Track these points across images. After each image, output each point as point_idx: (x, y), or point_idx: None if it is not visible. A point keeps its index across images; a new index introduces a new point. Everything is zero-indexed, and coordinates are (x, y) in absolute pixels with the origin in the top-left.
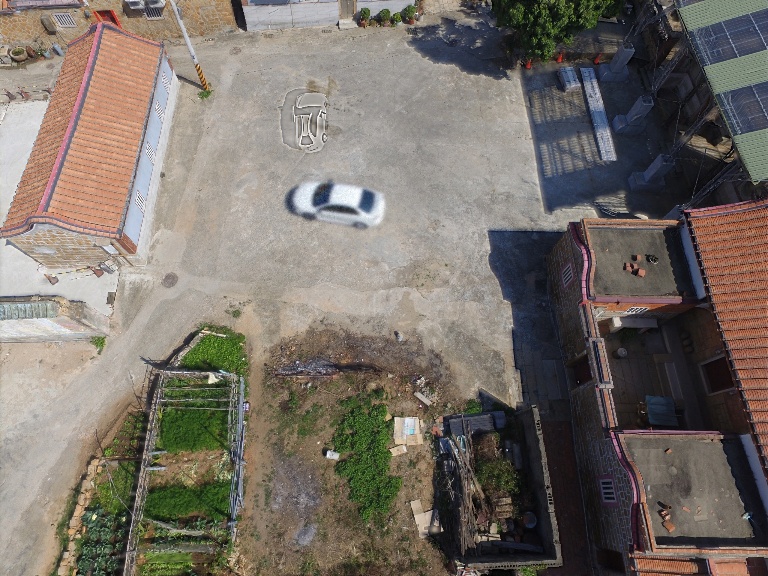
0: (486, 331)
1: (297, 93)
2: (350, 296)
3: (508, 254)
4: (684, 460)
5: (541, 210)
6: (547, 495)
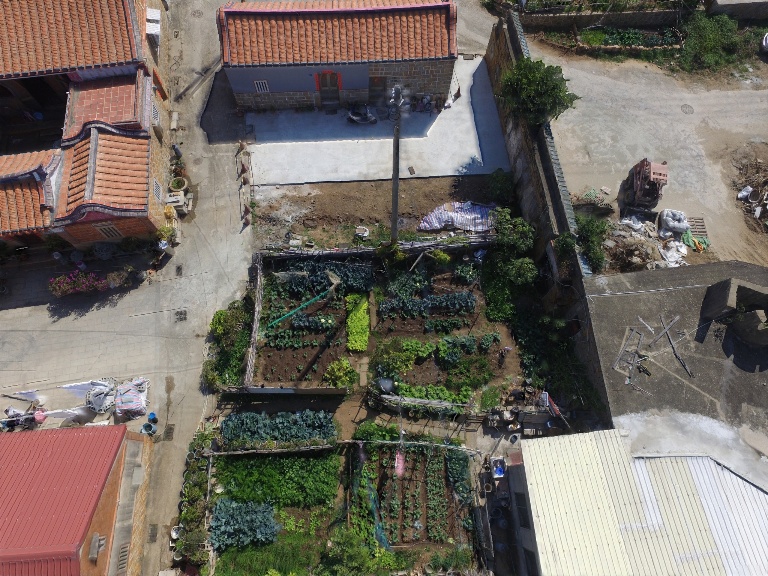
0: None
1: None
2: None
3: None
4: None
5: None
6: None
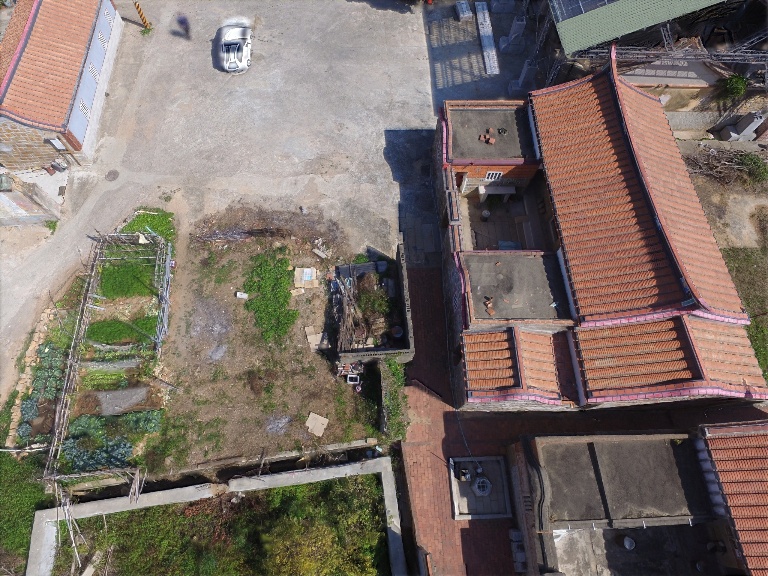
0: (377, 204)
1: (227, 28)
2: (264, 182)
3: (400, 147)
4: (510, 270)
5: (431, 113)
6: (406, 305)
